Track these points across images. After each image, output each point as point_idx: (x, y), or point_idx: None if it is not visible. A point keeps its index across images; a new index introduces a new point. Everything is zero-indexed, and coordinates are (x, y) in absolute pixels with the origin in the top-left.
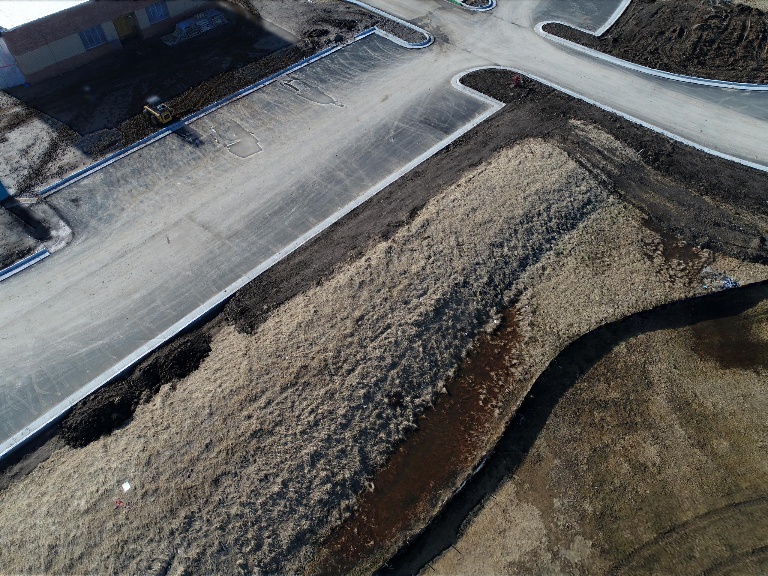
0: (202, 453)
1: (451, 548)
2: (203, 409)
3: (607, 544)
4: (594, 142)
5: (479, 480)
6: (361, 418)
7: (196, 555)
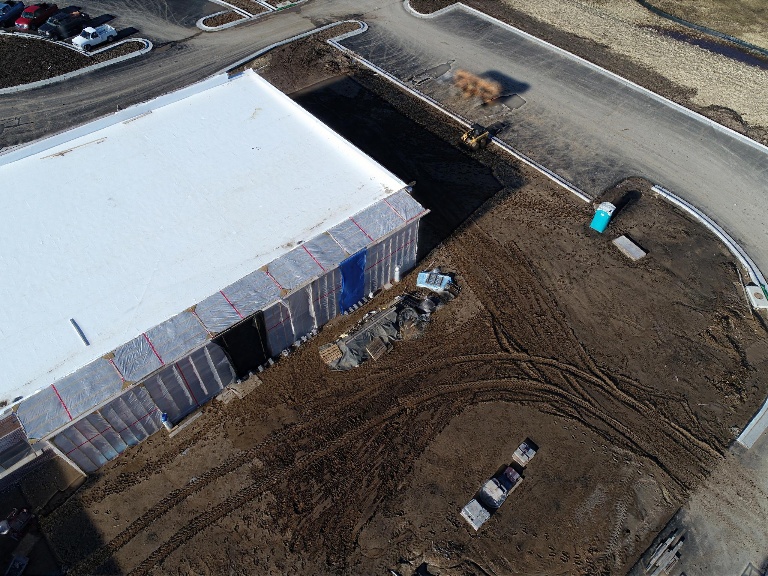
0: None
1: None
2: None
3: None
4: None
5: None
6: None
7: None
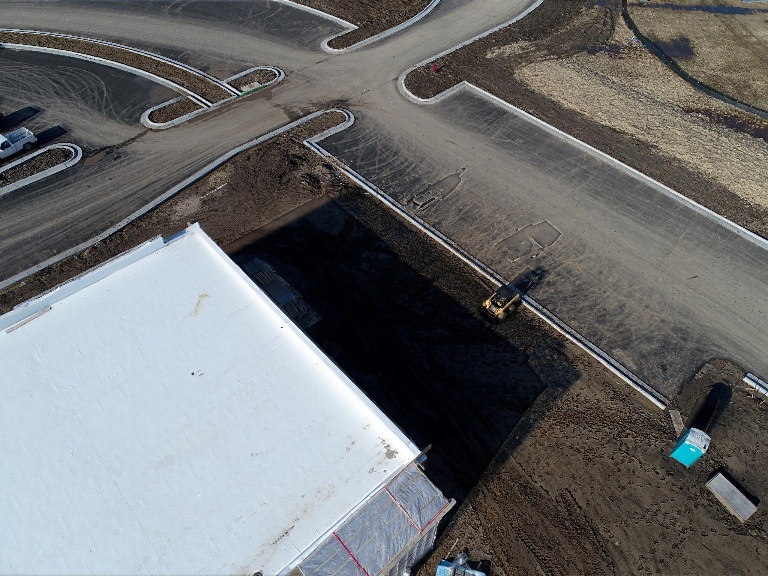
0: None
1: None
2: None
3: None
4: (516, 52)
5: None
6: None
7: None
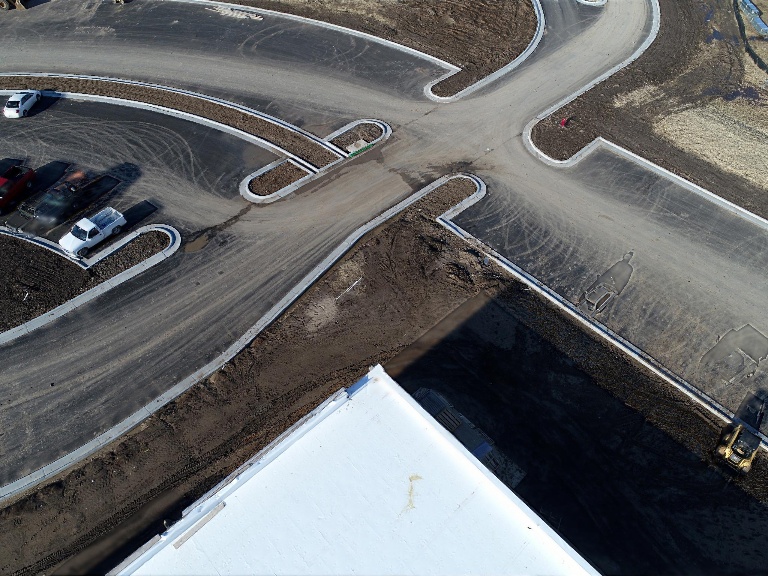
0: None
1: None
2: None
3: None
4: (647, 100)
5: None
6: None
7: None
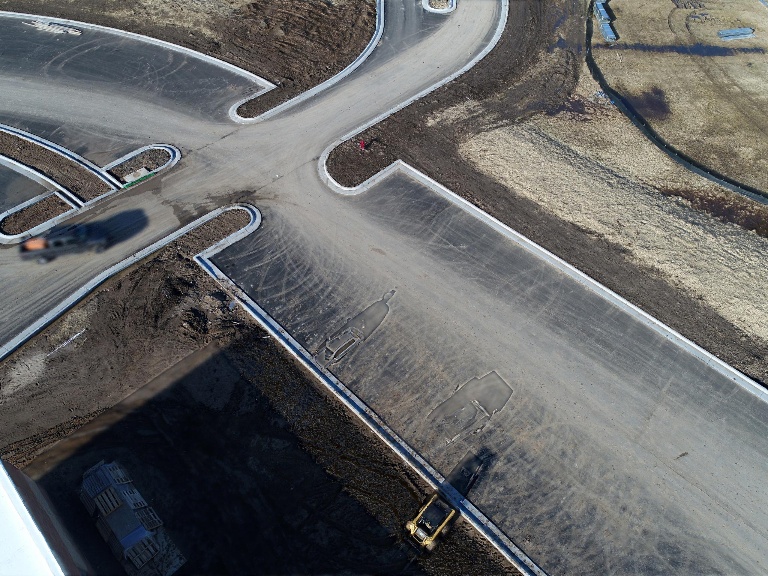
0: None
1: None
2: None
3: None
4: (462, 117)
5: None
6: None
7: None
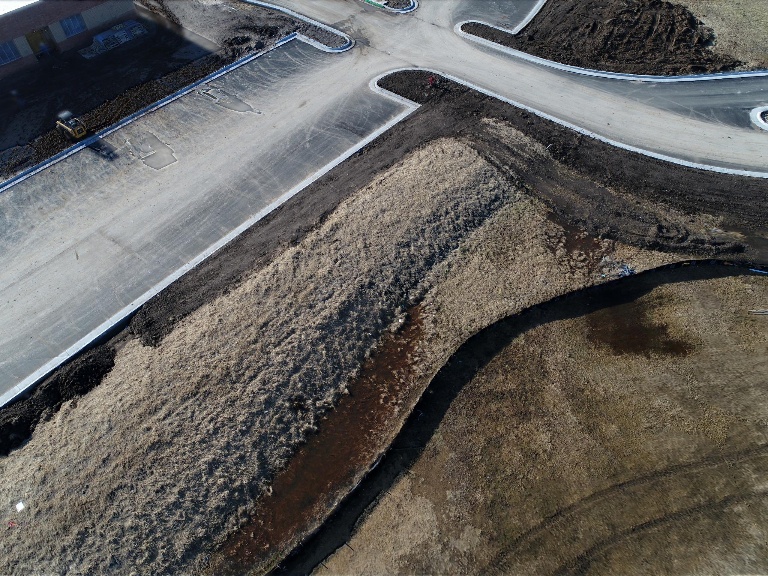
0: (99, 468)
1: (345, 546)
2: (102, 424)
3: (496, 531)
4: (504, 139)
5: (375, 477)
6: (261, 424)
7: (88, 570)
